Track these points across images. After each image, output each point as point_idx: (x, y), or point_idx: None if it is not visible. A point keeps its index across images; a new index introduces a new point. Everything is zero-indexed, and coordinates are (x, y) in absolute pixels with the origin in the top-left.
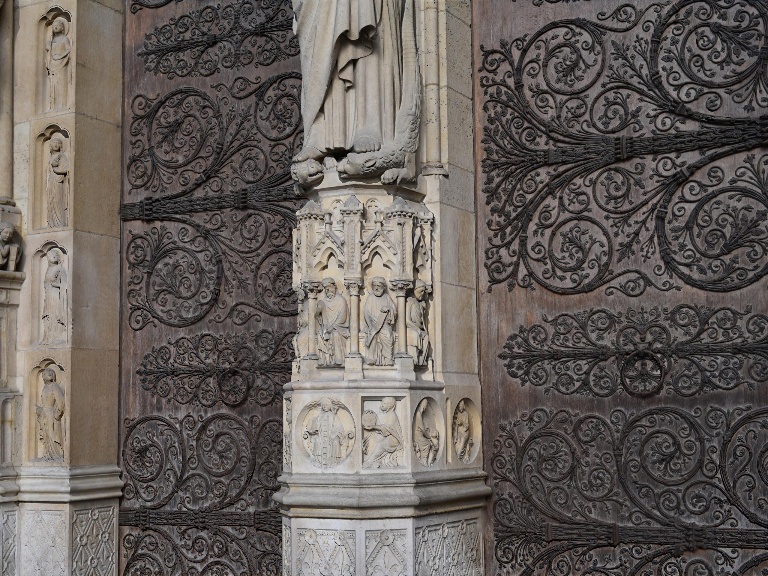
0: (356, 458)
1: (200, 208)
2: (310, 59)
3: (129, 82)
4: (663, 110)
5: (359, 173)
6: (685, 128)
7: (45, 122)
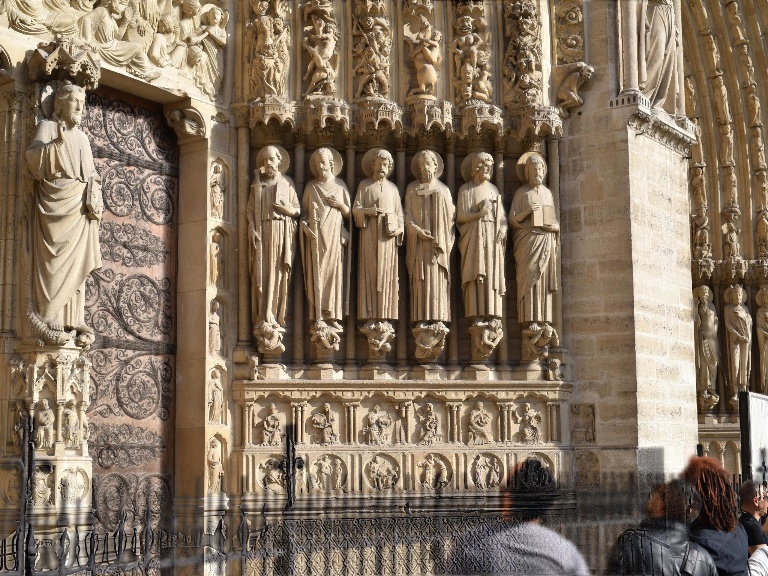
0: (89, 498)
1: None
2: (65, 273)
3: None
4: None
5: (88, 344)
6: None
7: None
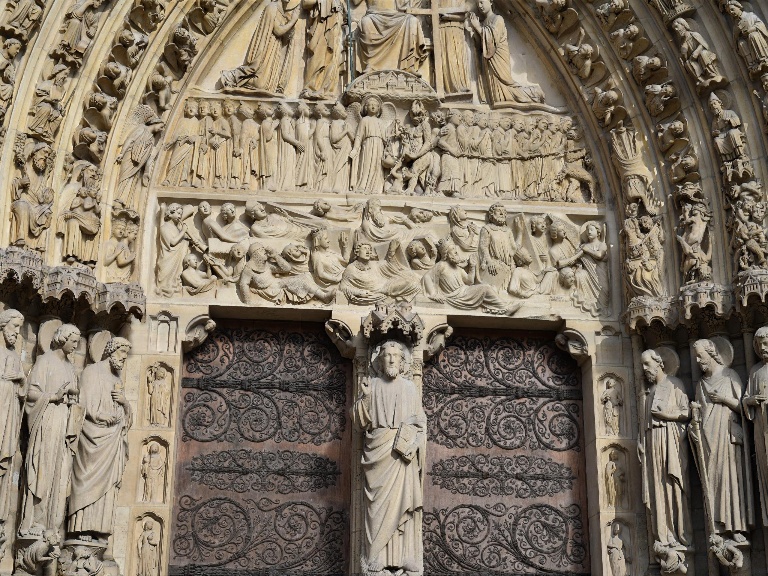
0: None
1: (232, 575)
2: (382, 516)
3: (178, 485)
4: (519, 560)
5: None
6: (529, 571)
7: (144, 509)
